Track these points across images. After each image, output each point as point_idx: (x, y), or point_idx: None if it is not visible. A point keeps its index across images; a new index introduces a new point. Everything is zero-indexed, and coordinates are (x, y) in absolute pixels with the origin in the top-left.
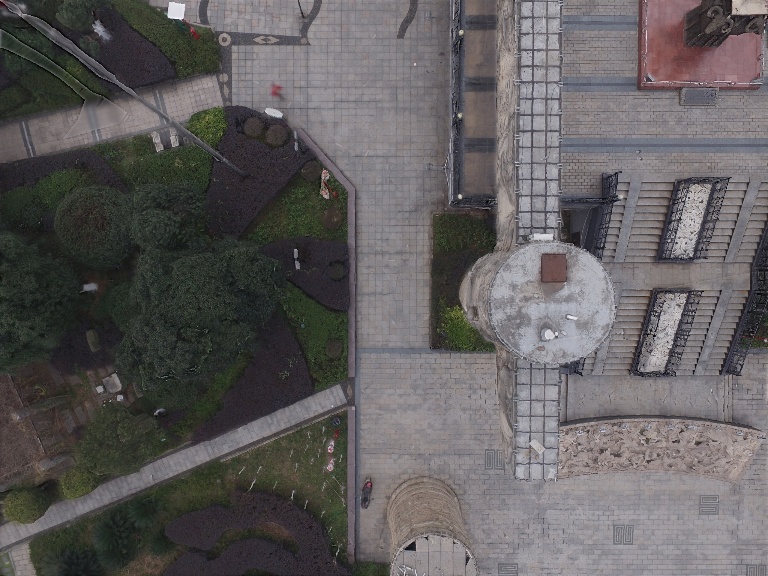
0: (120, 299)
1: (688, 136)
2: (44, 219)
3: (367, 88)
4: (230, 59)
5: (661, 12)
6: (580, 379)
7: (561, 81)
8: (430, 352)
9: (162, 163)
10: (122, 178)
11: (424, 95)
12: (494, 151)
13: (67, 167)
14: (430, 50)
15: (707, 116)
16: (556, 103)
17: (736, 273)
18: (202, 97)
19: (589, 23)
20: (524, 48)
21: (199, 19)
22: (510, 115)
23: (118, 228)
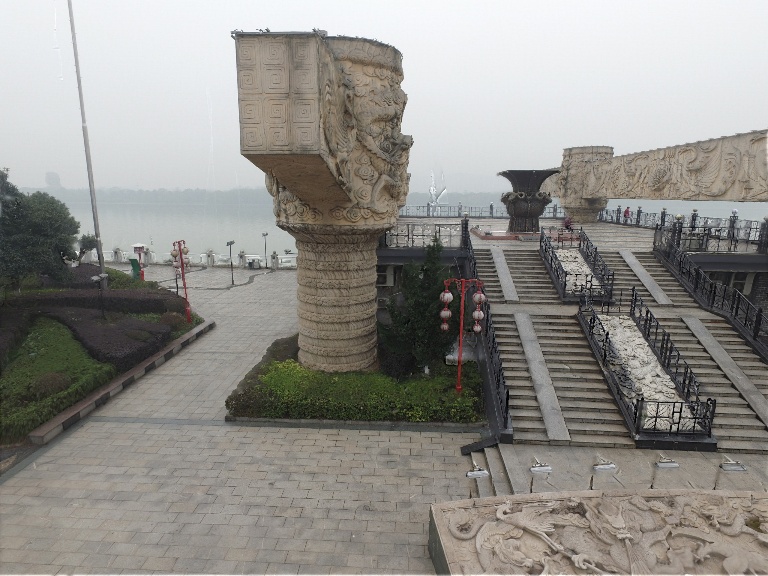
0: None
1: None
2: None
3: None
4: None
5: None
6: (528, 450)
7: None
8: (222, 424)
9: None
10: None
11: None
12: None
13: None
14: None
15: None
16: None
17: (687, 312)
18: None
19: None
20: None
21: None
22: None
23: None
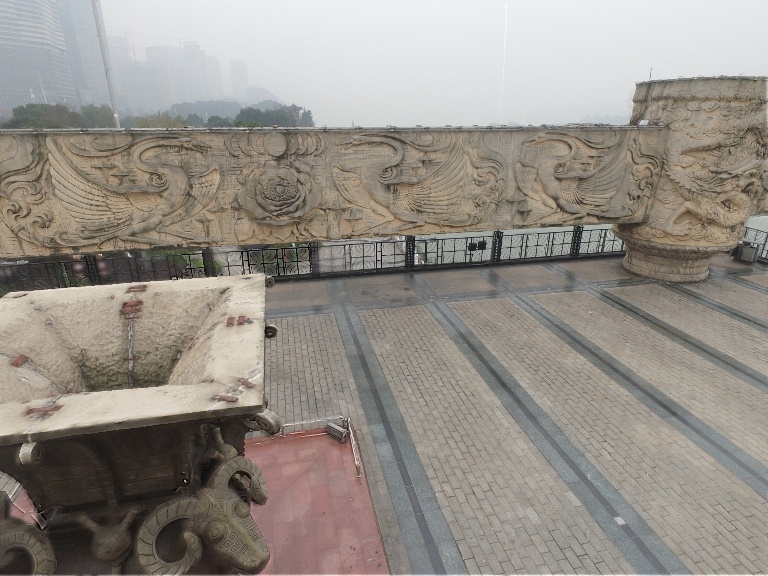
0: None
1: None
2: None
3: None
4: None
5: None
6: None
7: None
8: None
9: (175, 250)
10: None
11: None
12: None
13: None
14: None
15: None
16: None
17: None
18: None
19: None
20: None
21: None
22: None
23: None
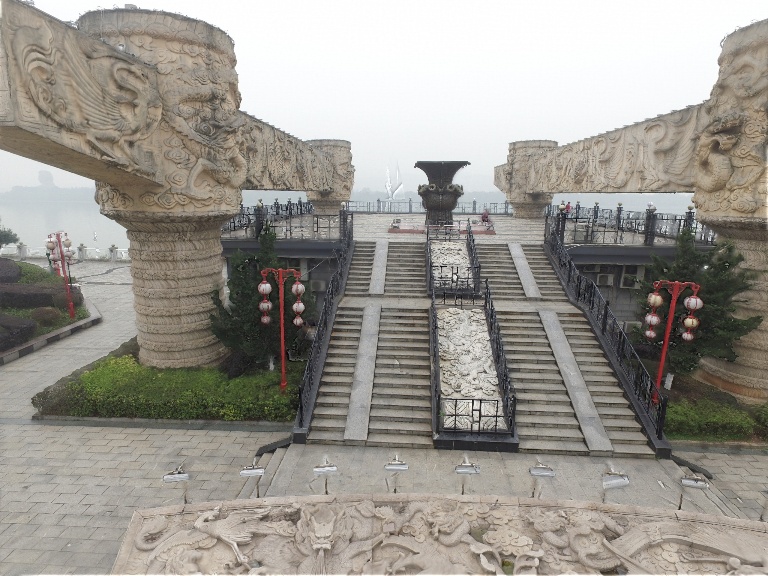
0: None
1: None
2: None
3: None
4: None
5: None
6: (317, 451)
7: None
8: (26, 423)
9: None
10: None
11: None
12: None
13: None
14: None
15: None
16: None
17: None
18: None
19: None
20: None
21: None
22: None
23: None
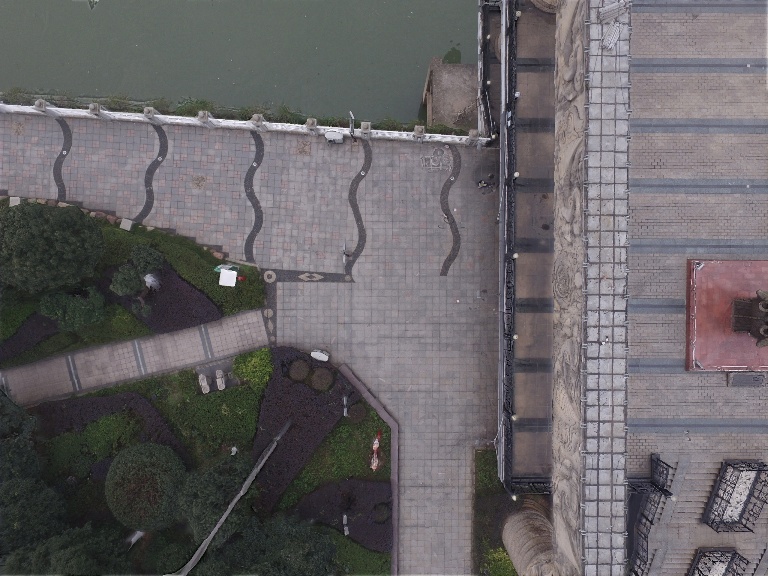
0: (170, 568)
1: (735, 417)
2: (93, 475)
3: (410, 324)
4: (275, 295)
5: (709, 298)
6: None
7: (626, 451)
8: None
9: (209, 409)
10: (169, 424)
11: (467, 331)
12: (544, 431)
13: (115, 413)
14: (473, 287)
15: (754, 397)
16: (621, 473)
17: None
18: (247, 332)
19: (638, 306)
20: (590, 420)
21: (245, 257)
22: (573, 467)
23: (169, 499)
